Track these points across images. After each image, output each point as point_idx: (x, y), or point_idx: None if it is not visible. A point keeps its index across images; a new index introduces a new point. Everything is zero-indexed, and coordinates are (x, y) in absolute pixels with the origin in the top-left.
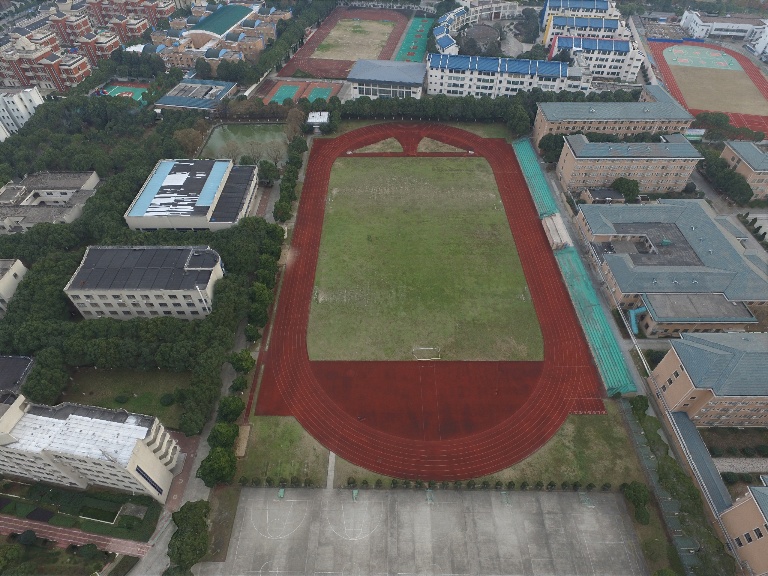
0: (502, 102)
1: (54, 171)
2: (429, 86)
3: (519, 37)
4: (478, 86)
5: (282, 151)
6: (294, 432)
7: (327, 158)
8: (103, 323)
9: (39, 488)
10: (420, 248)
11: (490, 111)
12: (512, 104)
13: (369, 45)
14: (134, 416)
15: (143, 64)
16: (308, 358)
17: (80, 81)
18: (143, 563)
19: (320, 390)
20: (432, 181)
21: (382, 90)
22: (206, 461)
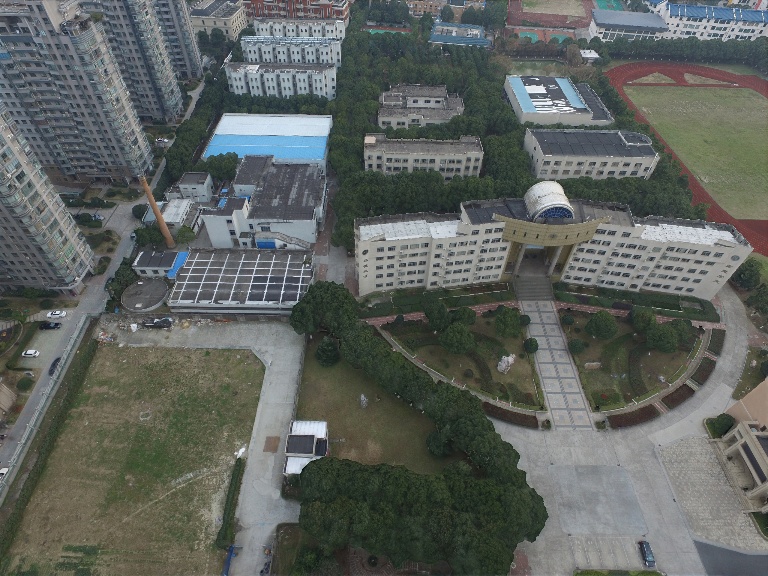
0: (752, 44)
1: None
2: (662, 34)
3: (701, 0)
4: (710, 34)
5: (591, 75)
6: (767, 262)
7: (614, 86)
8: (592, 179)
9: (607, 289)
10: (756, 149)
11: (740, 52)
12: (762, 45)
13: (568, 3)
14: (709, 225)
15: (392, 10)
16: (733, 218)
17: (344, 22)
18: (728, 334)
19: (763, 237)
20: (722, 104)
21: (626, 35)
22: (748, 266)
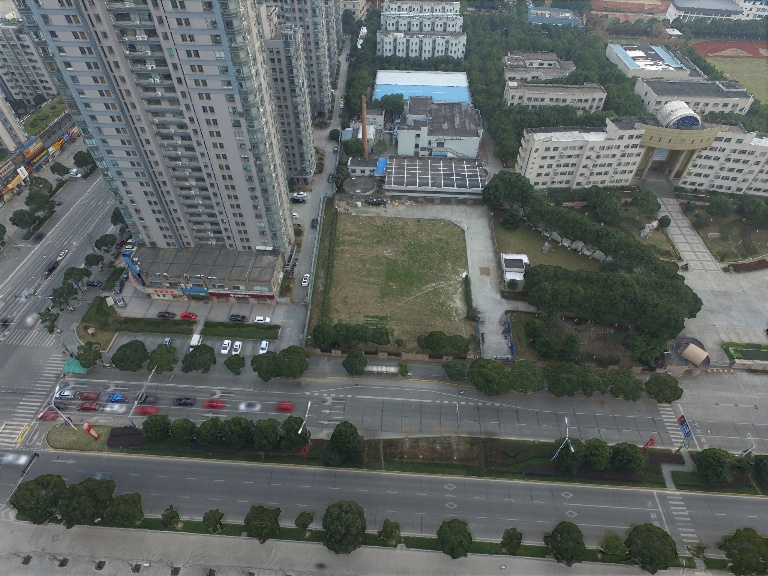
0: None
1: (524, 51)
2: None
3: None
4: None
5: None
6: None
7: None
8: None
9: (717, 191)
10: None
11: None
12: None
13: None
14: None
15: None
16: None
17: None
18: None
19: None
20: None
21: None
22: None
